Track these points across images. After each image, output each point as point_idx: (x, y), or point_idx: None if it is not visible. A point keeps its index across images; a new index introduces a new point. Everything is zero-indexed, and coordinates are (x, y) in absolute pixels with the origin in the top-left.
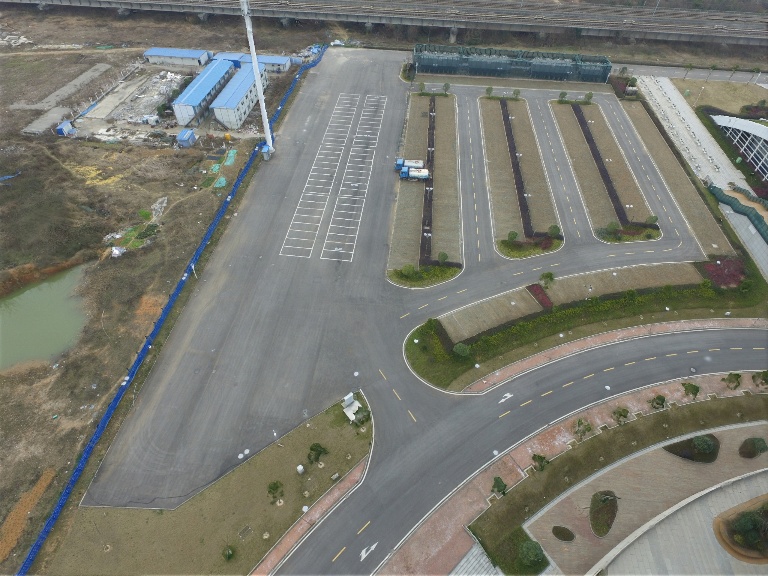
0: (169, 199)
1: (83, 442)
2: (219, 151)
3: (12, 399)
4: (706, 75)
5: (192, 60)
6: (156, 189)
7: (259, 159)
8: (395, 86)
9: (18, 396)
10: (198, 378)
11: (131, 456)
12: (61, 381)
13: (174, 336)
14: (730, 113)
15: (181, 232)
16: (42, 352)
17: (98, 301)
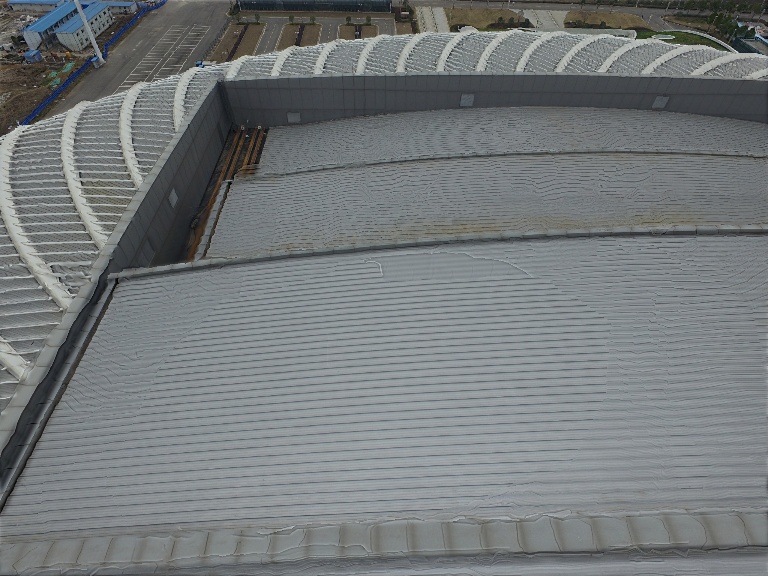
0: (12, 93)
1: None
2: (59, 64)
3: None
4: (474, 5)
5: (50, 6)
6: (3, 88)
7: (91, 67)
8: (220, 20)
9: None
10: None
11: None
12: None
13: None
14: (477, 28)
15: (18, 111)
16: None
17: None
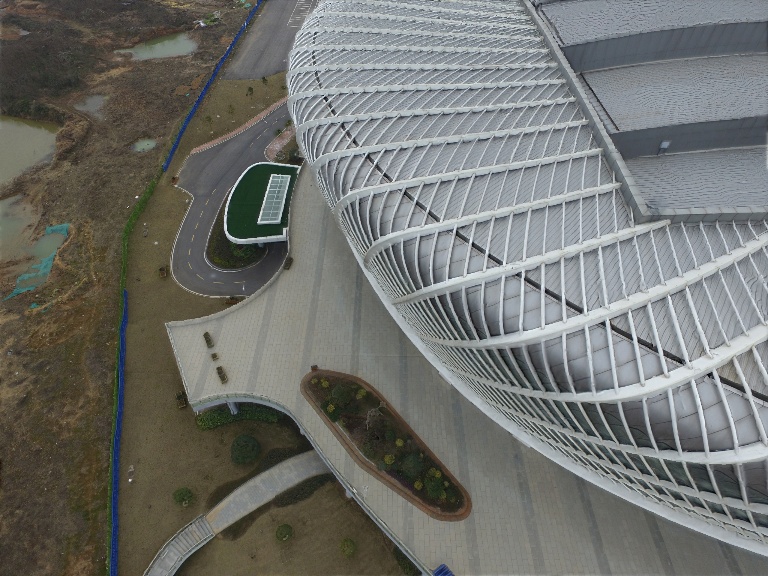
0: (221, 11)
1: (214, 68)
2: None
3: (175, 61)
4: None
5: None
6: (212, 8)
7: None
8: None
9: (178, 61)
10: (258, 55)
11: (236, 71)
12: (195, 57)
13: (242, 47)
14: None
15: (233, 20)
16: (181, 51)
17: (200, 39)
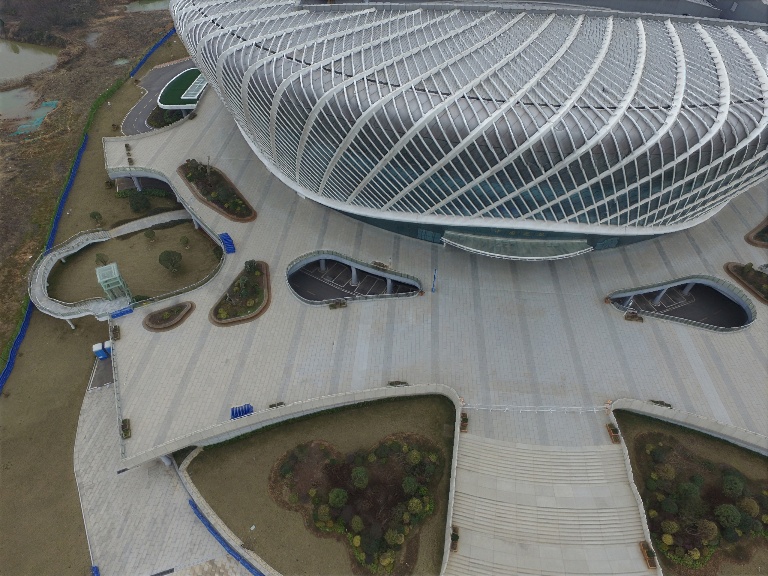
0: None
1: None
2: None
3: (158, 13)
4: None
5: None
6: None
7: None
8: None
9: None
10: None
11: None
12: None
13: None
14: None
15: None
16: (165, 7)
17: None
